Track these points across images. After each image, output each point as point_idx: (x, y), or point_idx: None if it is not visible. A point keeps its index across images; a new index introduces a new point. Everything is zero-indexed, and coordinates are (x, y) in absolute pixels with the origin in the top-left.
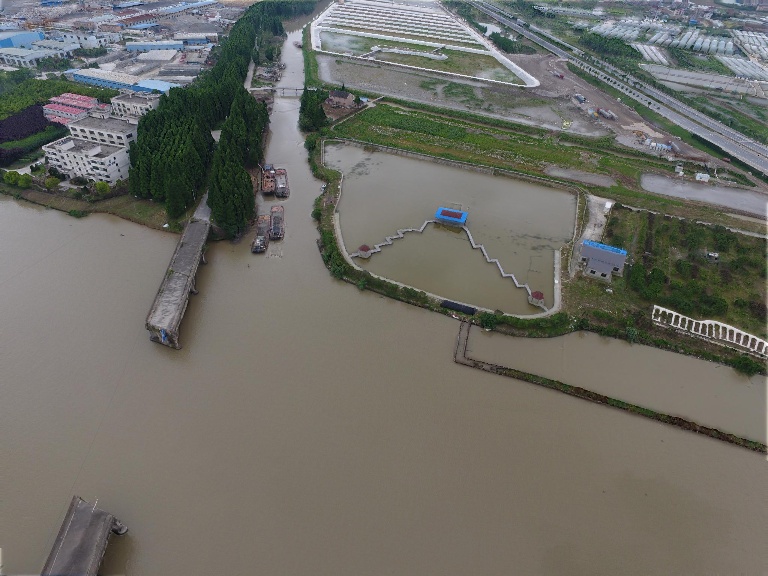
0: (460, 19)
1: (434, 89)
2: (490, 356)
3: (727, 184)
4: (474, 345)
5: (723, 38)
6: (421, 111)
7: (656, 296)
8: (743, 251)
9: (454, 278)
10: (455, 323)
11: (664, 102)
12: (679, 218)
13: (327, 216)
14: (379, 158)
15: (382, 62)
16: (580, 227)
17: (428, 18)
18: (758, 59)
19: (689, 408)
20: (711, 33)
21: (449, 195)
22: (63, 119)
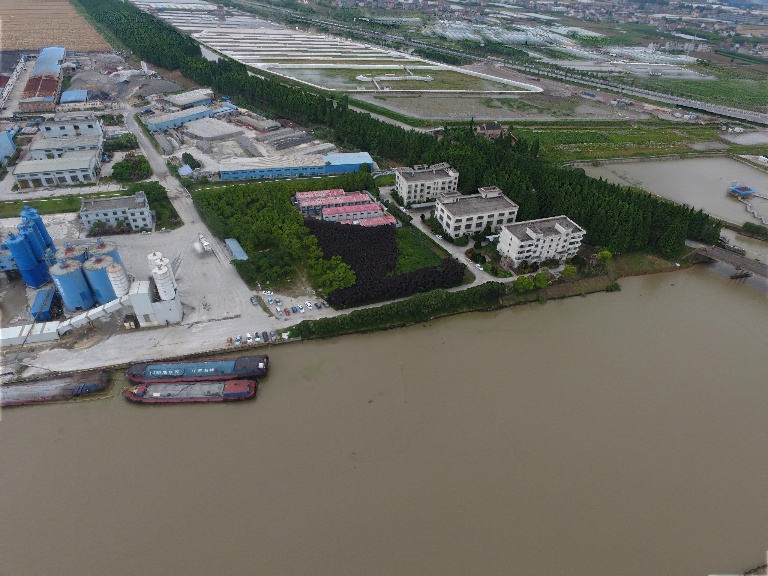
0: None
1: (502, 107)
2: None
3: (750, 131)
4: None
5: (519, 32)
6: (538, 127)
7: None
8: None
9: None
10: None
11: None
12: None
13: (709, 217)
14: (616, 169)
15: (413, 91)
16: None
17: (310, 40)
18: None
19: None
20: None
21: None
22: (371, 220)
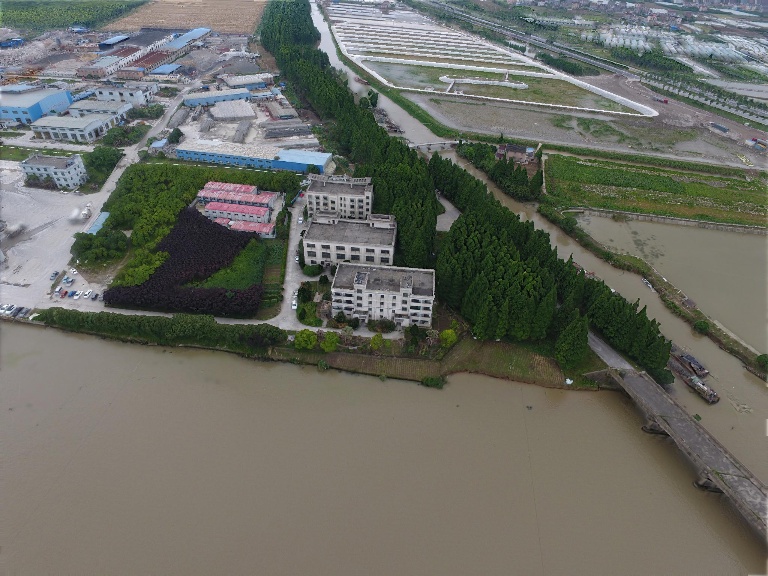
0: (472, 36)
1: (572, 128)
2: None
3: None
4: None
5: (717, 44)
6: (595, 158)
7: None
8: None
9: None
10: None
11: None
12: None
13: (714, 328)
14: (644, 230)
15: (481, 98)
16: None
17: (442, 37)
18: None
19: None
20: (696, 38)
21: None
22: (246, 224)
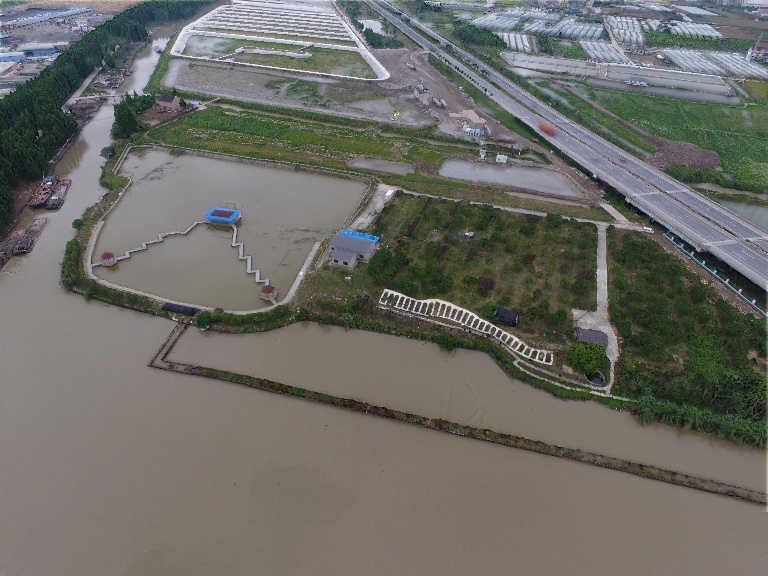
0: (346, 17)
1: (278, 88)
2: (195, 356)
3: (523, 164)
4: (181, 346)
5: (596, 24)
6: (254, 111)
7: (386, 280)
8: (500, 228)
9: (196, 279)
10: (172, 325)
11: (504, 88)
12: (457, 200)
13: (88, 225)
14: (182, 161)
15: (237, 63)
16: (353, 217)
17: (313, 17)
18: (619, 42)
19: (374, 389)
20: None
21: (230, 194)
22: None
